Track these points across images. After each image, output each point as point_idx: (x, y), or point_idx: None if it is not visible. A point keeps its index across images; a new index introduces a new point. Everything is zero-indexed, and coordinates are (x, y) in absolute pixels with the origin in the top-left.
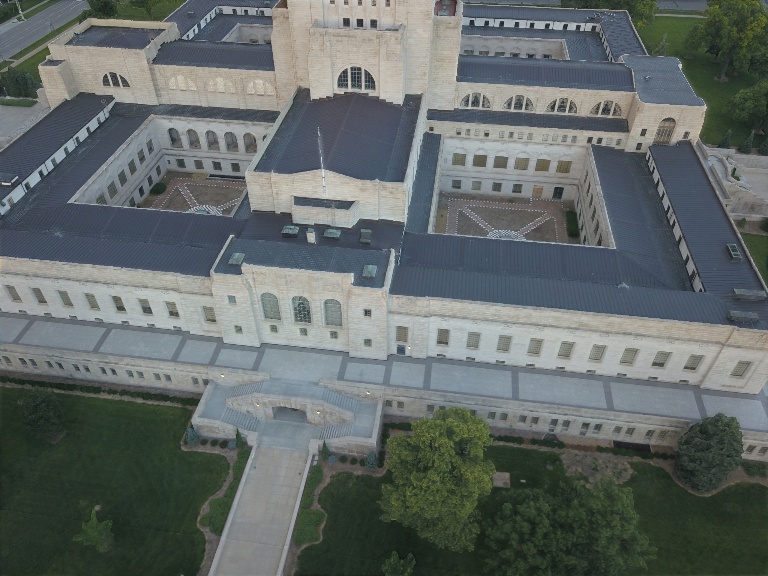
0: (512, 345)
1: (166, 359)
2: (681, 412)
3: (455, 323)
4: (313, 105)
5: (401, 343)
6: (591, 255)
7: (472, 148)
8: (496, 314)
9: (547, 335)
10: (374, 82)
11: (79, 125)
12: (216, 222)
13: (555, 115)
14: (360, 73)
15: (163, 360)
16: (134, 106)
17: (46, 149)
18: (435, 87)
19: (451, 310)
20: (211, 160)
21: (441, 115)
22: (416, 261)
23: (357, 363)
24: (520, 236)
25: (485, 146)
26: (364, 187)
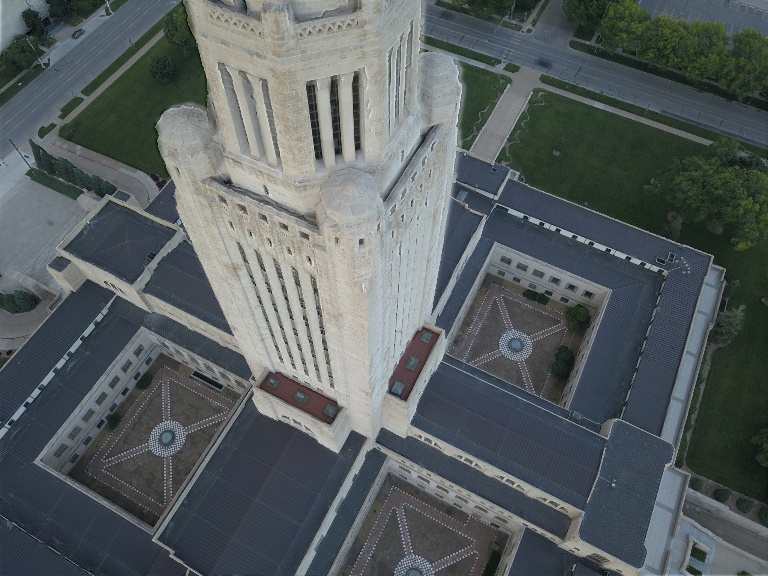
0: None
1: None
2: None
3: None
4: (259, 422)
5: None
6: None
7: None
8: None
9: None
10: None
11: (72, 339)
12: (138, 536)
13: (502, 483)
14: None
15: None
16: (131, 305)
17: (35, 375)
18: (387, 422)
19: None
20: (194, 366)
21: (392, 439)
22: None
23: None
24: (431, 573)
25: (427, 478)
26: None
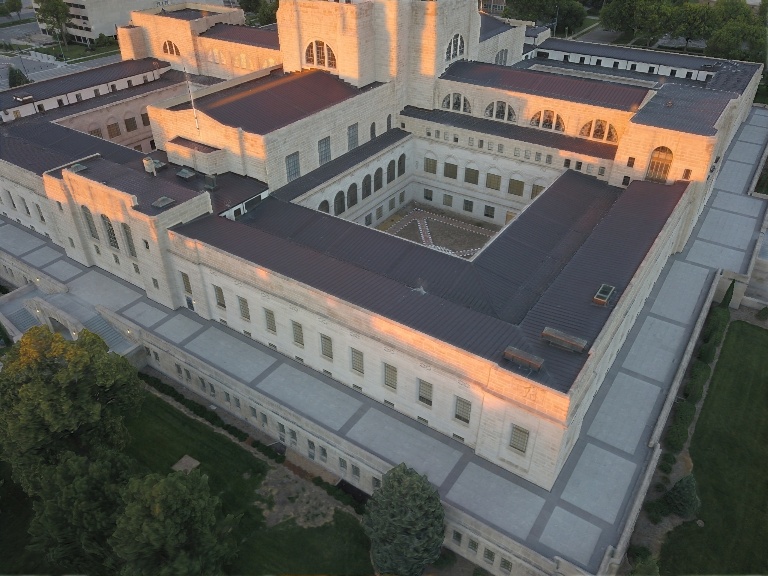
0: (276, 324)
1: (15, 254)
2: (422, 469)
3: (222, 280)
4: (281, 77)
5: (188, 294)
6: (436, 261)
7: (442, 154)
8: (252, 276)
9: (302, 319)
10: (336, 60)
11: (121, 76)
12: (131, 155)
13: (539, 130)
14: (324, 49)
15: (12, 254)
16: (182, 74)
17: (78, 86)
18: (414, 81)
19: (216, 261)
20: None
21: (418, 113)
22: (255, 222)
23: (147, 304)
24: None
25: (454, 153)
26: (227, 134)
